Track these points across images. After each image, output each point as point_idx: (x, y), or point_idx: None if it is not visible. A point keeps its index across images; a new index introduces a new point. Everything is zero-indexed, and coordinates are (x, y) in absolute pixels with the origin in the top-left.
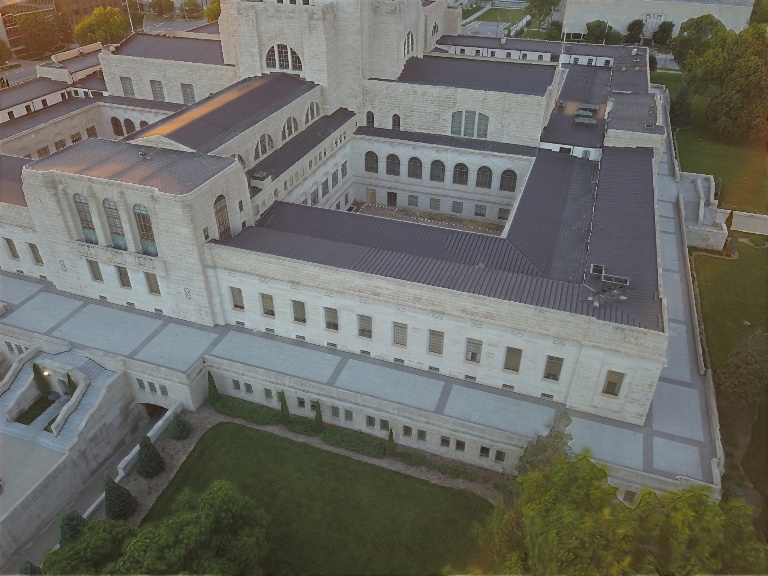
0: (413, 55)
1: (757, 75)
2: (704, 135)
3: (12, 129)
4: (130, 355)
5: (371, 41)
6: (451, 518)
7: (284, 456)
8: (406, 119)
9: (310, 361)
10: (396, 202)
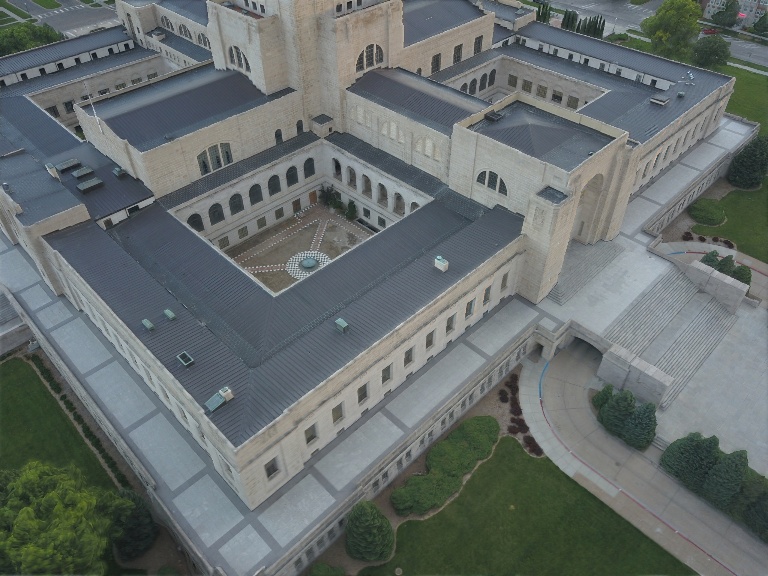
0: (249, 76)
1: None
2: None
3: None
4: None
5: None
6: None
7: None
8: None
9: None
10: None
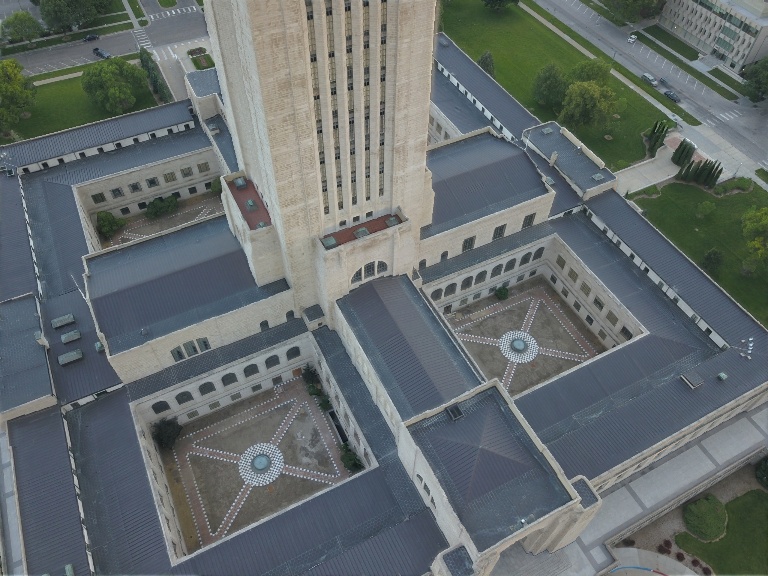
0: None
1: None
2: None
3: (457, 108)
4: None
5: None
6: None
7: None
8: None
9: None
10: None
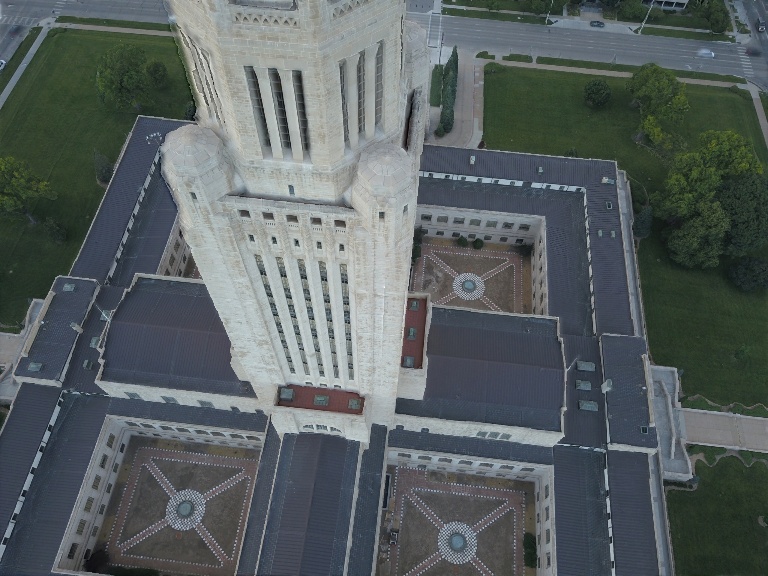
0: None
1: (717, 229)
2: (661, 250)
3: (50, 500)
4: None
5: (399, 386)
6: None
7: None
8: (435, 430)
9: None
10: (426, 467)
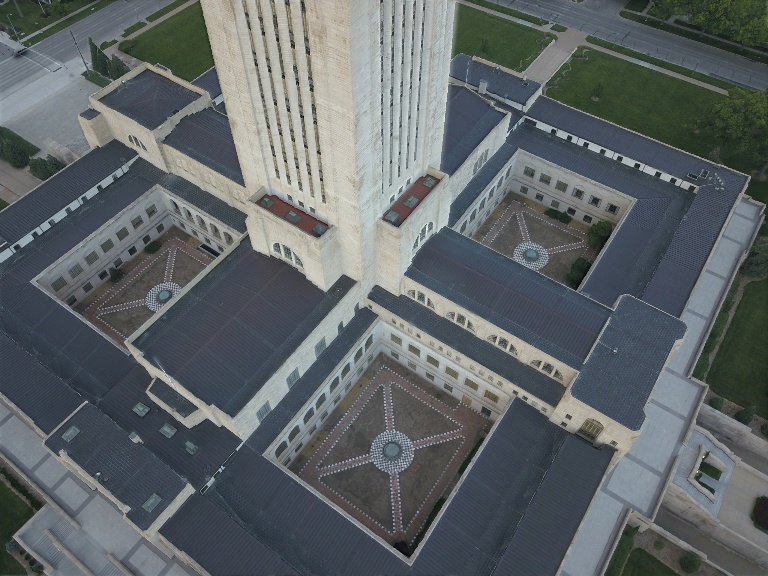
0: None
1: None
2: None
3: None
4: (684, 419)
5: None
6: (759, 298)
7: (729, 356)
8: None
9: (688, 325)
10: None
